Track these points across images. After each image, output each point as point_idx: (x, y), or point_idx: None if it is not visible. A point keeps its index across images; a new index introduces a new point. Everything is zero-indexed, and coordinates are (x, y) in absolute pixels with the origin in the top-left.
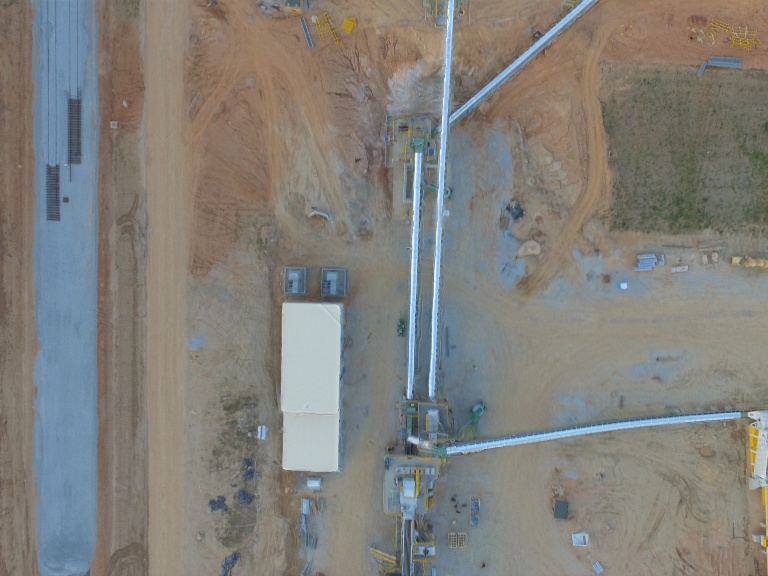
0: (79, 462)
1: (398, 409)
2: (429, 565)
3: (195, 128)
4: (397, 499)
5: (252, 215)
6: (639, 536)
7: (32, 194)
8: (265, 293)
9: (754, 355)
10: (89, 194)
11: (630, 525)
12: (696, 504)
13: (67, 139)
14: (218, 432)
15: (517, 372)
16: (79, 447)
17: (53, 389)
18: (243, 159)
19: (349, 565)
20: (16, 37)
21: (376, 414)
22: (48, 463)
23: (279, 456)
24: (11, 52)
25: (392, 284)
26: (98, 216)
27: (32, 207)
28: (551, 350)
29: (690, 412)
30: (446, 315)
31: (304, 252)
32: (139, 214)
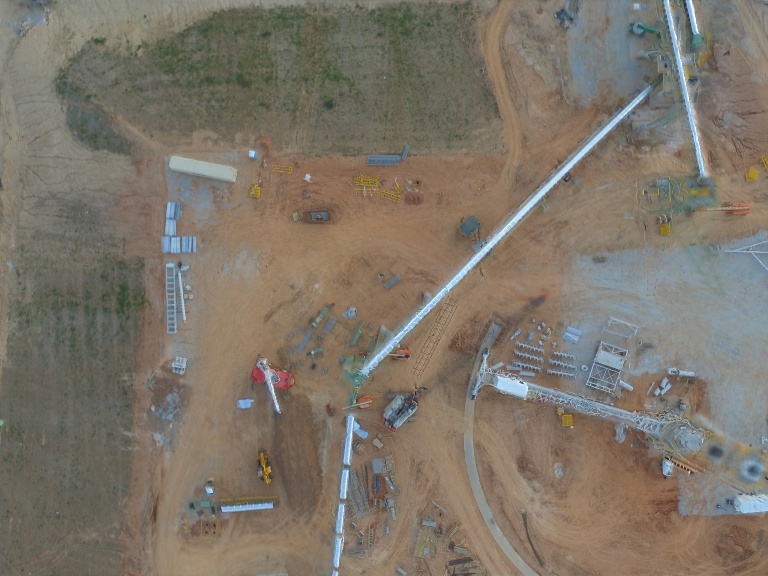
0: None
1: None
2: None
3: None
4: None
5: None
6: None
7: None
8: None
9: None
10: None
11: None
12: None
13: None
14: None
15: None
16: None
17: None
18: None
19: None
20: None
21: None
22: None
23: None
24: None
25: None
26: None
27: None
28: None
29: None
30: None
31: None
32: None
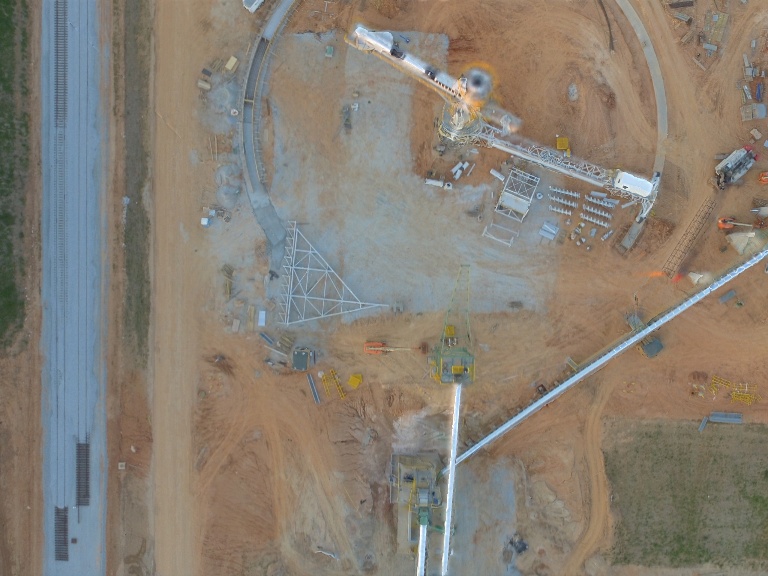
0: None
1: None
2: None
3: (202, 479)
4: None
5: (258, 555)
6: None
7: (41, 534)
8: None
9: None
10: (97, 535)
11: None
12: None
13: (75, 482)
14: None
15: None
16: None
17: None
18: (250, 504)
19: None
20: (25, 383)
21: None
22: None
23: None
24: (20, 399)
25: None
26: (106, 555)
27: (41, 547)
28: None
29: None
30: None
31: None
32: (147, 559)
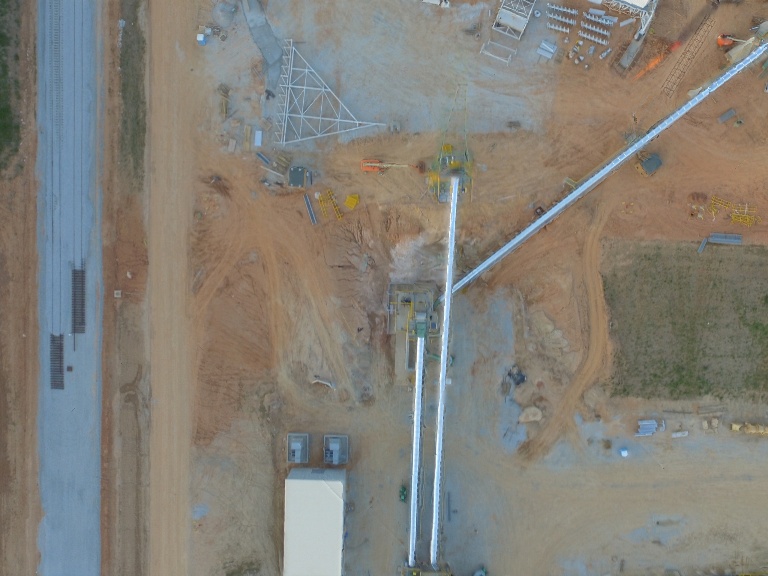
0: None
1: (400, 573)
2: None
3: (199, 302)
4: None
5: (255, 384)
6: None
7: (36, 363)
8: (268, 460)
9: (754, 519)
10: (93, 363)
11: None
12: None
13: (71, 309)
14: None
15: (518, 536)
16: None
17: (57, 555)
18: (246, 330)
19: None
20: (21, 208)
21: None
22: None
23: None
24: (16, 224)
25: (394, 450)
26: (102, 384)
27: (36, 375)
28: (552, 514)
29: None
30: (448, 481)
31: (307, 418)
32: (143, 385)
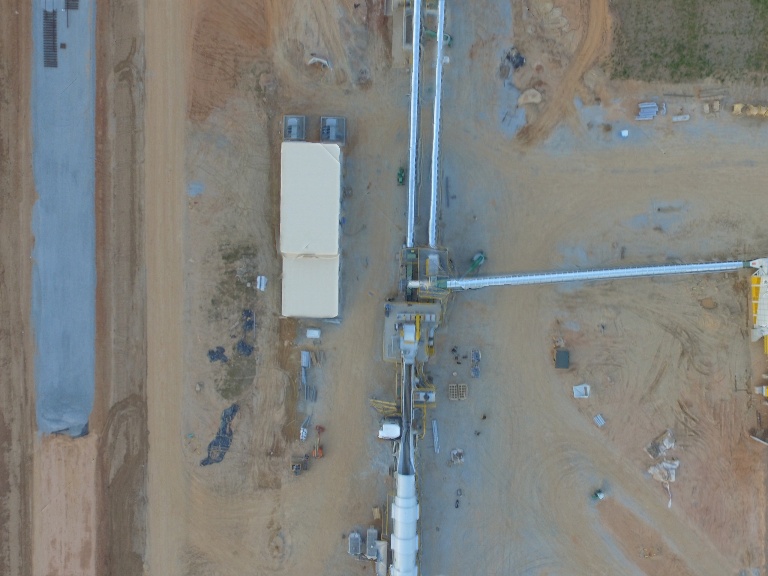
0: (77, 313)
1: (398, 260)
2: (430, 418)
3: None
4: (397, 344)
5: (251, 61)
6: (641, 388)
7: (29, 40)
8: (264, 141)
9: (756, 205)
10: (86, 40)
11: (632, 377)
12: (698, 356)
13: None
14: (217, 281)
15: (518, 222)
16: (77, 297)
17: (51, 238)
18: (241, 3)
19: (349, 418)
20: None
21: (376, 265)
22: (46, 314)
23: (278, 304)
24: None
25: (392, 132)
26: (96, 63)
27: (29, 54)
28: (552, 200)
29: (692, 262)
30: (446, 163)
31: (303, 101)
32: (137, 58)
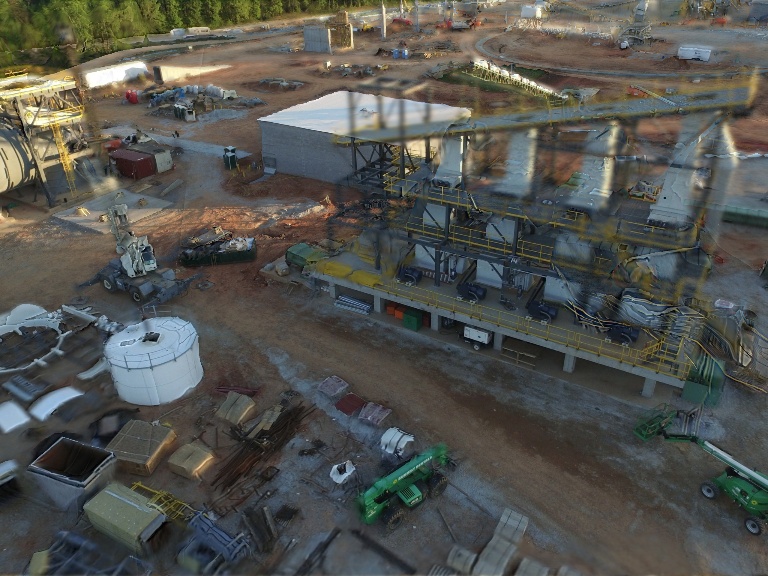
0: None
1: None
2: None
3: None
4: (726, 1)
5: None
6: None
7: None
8: None
9: None
10: None
11: None
12: None
13: None
14: None
15: None
16: None
17: None
18: None
19: None
20: None
21: None
22: None
23: None
24: None
25: None
26: None
27: None
28: None
29: None
30: None
31: None
32: None
